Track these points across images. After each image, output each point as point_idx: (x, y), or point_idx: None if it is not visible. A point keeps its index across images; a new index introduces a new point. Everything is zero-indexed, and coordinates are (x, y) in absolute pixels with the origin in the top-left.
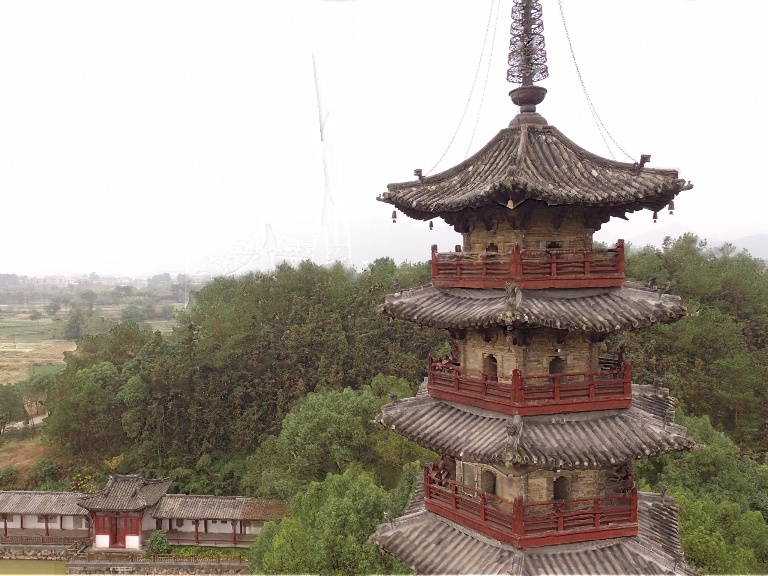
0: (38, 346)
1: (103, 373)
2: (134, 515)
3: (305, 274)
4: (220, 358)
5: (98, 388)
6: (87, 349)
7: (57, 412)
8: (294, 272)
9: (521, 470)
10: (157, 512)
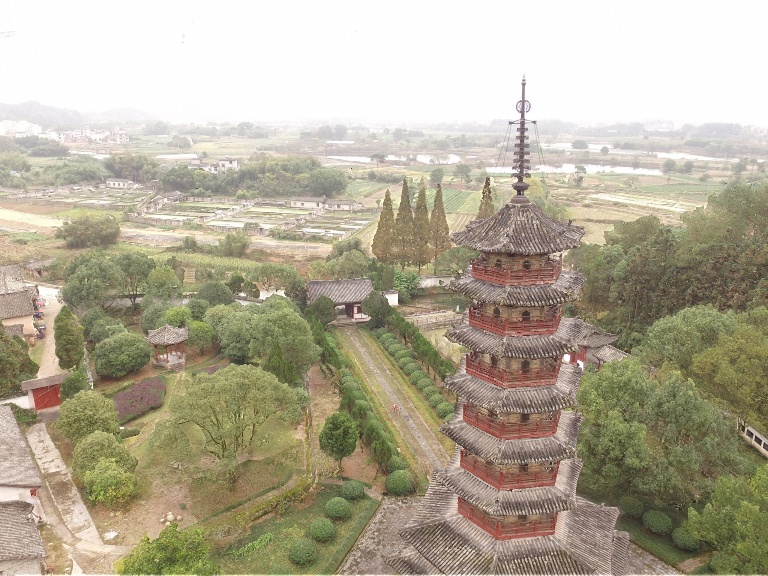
0: (692, 207)
1: (611, 253)
2: (583, 349)
3: None
4: (685, 260)
5: (604, 262)
6: (619, 232)
7: None
8: None
9: (450, 340)
10: (596, 353)
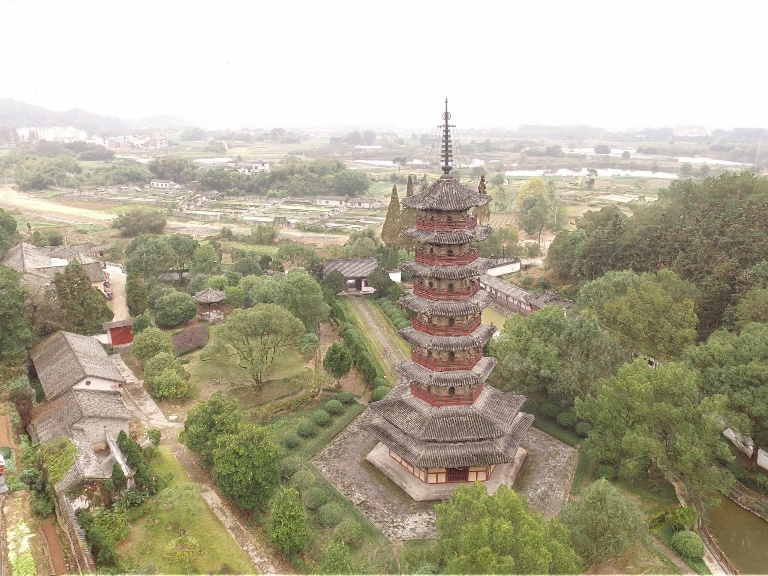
0: None
1: (576, 236)
2: None
3: (726, 185)
4: (628, 239)
5: (569, 244)
6: (587, 220)
7: (550, 253)
8: (721, 182)
9: None
10: None
